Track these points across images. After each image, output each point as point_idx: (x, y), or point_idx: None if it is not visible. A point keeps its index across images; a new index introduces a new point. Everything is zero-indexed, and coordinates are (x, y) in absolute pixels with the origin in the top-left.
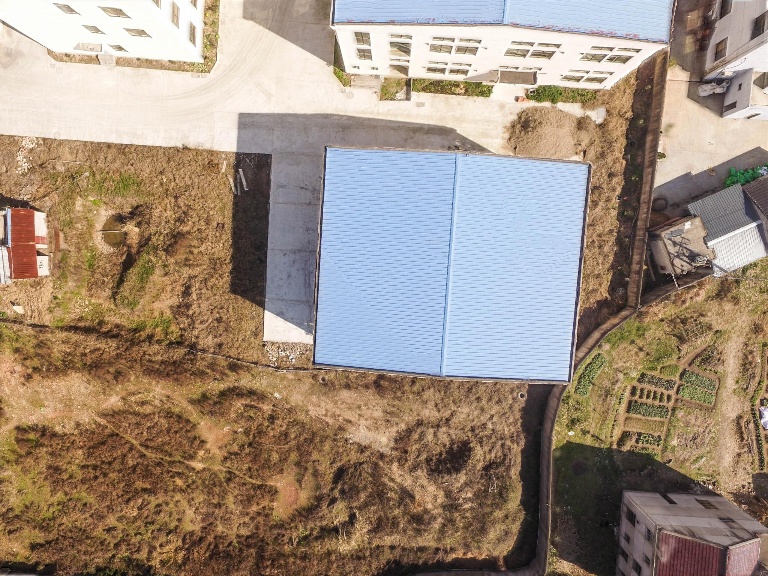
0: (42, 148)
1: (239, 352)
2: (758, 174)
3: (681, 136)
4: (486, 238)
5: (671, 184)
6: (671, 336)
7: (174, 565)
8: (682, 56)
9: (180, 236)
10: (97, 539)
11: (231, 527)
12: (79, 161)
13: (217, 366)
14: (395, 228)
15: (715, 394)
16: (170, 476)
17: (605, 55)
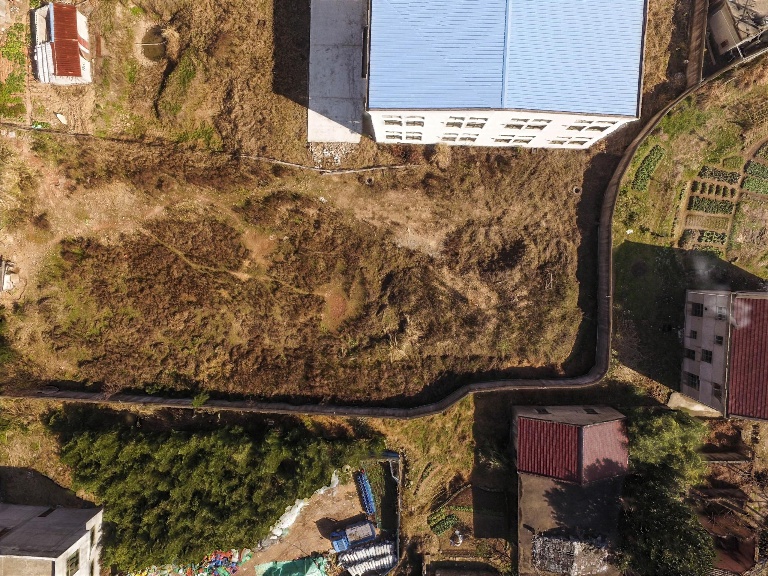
0: None
1: (283, 154)
2: None
3: None
4: None
5: None
6: (734, 124)
7: (222, 379)
8: None
9: None
10: (144, 355)
11: (279, 339)
12: None
13: (261, 170)
14: None
15: None
16: (216, 287)
17: None
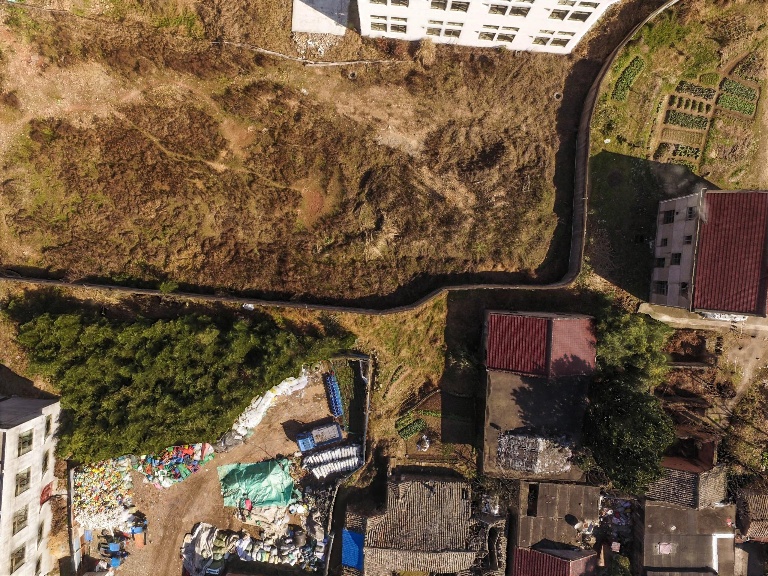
0: None
1: (266, 42)
2: None
3: None
4: None
5: None
6: (712, 40)
7: (192, 270)
8: None
9: None
10: (112, 243)
11: (253, 233)
12: None
13: (243, 58)
14: None
15: (755, 105)
16: (191, 176)
17: None
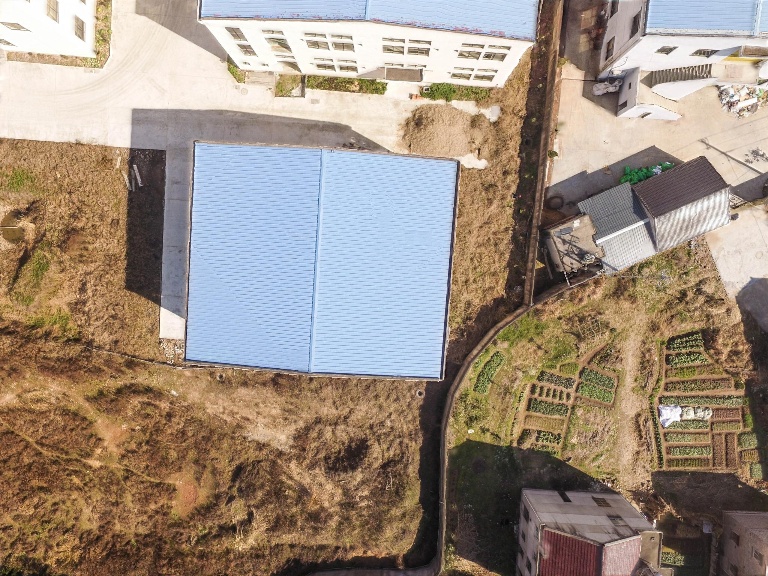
0: None
1: (135, 349)
2: (652, 173)
3: (576, 135)
4: (353, 234)
5: (567, 182)
6: (569, 334)
7: (71, 564)
8: (577, 55)
9: (74, 232)
10: None
11: (129, 526)
12: None
13: (113, 363)
14: (263, 224)
15: (614, 392)
16: (66, 474)
17: (478, 52)
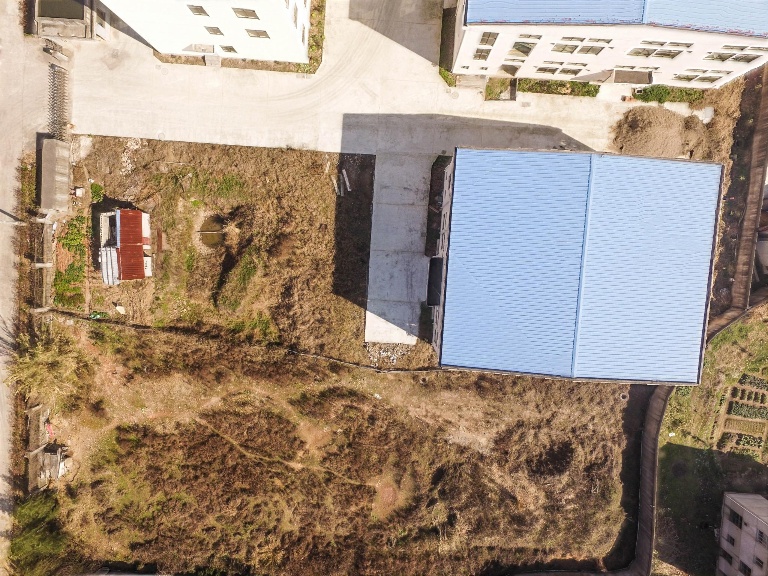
0: (146, 149)
1: (340, 353)
2: None
3: None
4: (619, 239)
5: None
6: None
7: (273, 565)
8: None
9: (283, 237)
10: (196, 539)
11: (330, 527)
12: (183, 162)
13: (318, 367)
14: (526, 229)
15: None
16: (270, 476)
17: (734, 54)
